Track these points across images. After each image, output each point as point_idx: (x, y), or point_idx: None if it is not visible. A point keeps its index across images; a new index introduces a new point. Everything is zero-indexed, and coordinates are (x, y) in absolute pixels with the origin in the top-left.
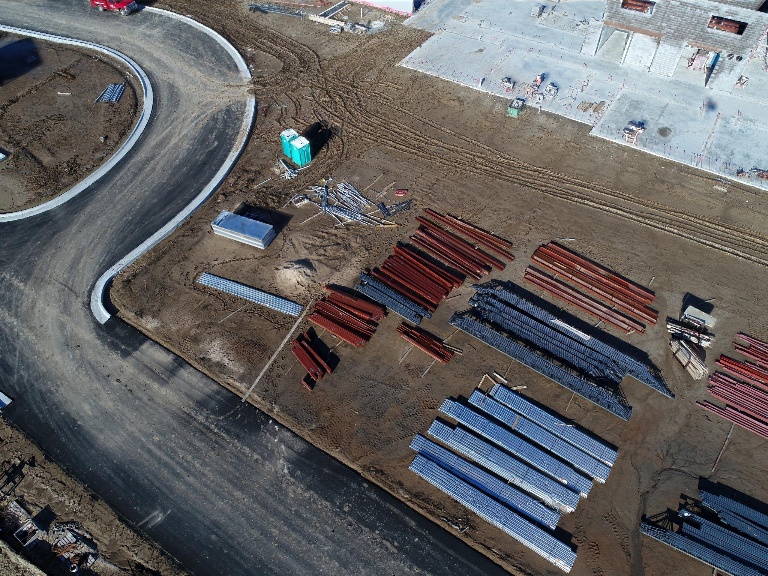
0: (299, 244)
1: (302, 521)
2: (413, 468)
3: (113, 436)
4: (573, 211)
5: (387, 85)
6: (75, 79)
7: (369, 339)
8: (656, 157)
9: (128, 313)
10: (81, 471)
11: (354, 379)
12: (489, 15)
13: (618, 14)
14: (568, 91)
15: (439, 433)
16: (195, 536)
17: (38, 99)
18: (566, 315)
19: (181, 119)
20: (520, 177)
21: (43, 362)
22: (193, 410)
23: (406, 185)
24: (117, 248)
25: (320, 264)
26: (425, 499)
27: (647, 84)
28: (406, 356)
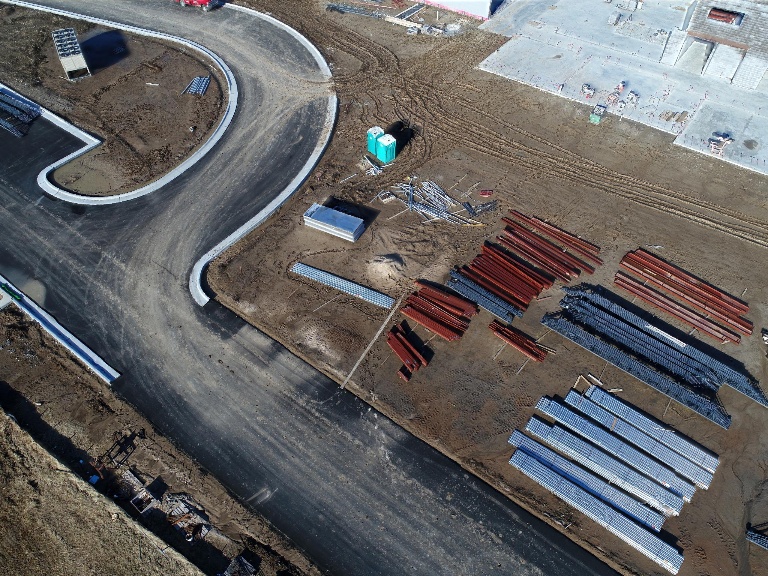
0: (388, 239)
1: (406, 507)
2: (514, 463)
3: (218, 414)
4: (660, 219)
5: (466, 87)
6: (162, 71)
7: (462, 335)
8: (743, 169)
9: (226, 297)
10: (190, 445)
11: (449, 373)
12: (565, 22)
13: (704, 25)
14: (649, 100)
15: (537, 430)
16: (303, 514)
17: (128, 89)
18: (659, 321)
19: (266, 113)
20: (604, 183)
21: (147, 340)
22: (294, 394)
23: (490, 186)
24: (212, 234)
25: (410, 259)
26: (526, 494)
27: (730, 96)
28: (500, 353)
